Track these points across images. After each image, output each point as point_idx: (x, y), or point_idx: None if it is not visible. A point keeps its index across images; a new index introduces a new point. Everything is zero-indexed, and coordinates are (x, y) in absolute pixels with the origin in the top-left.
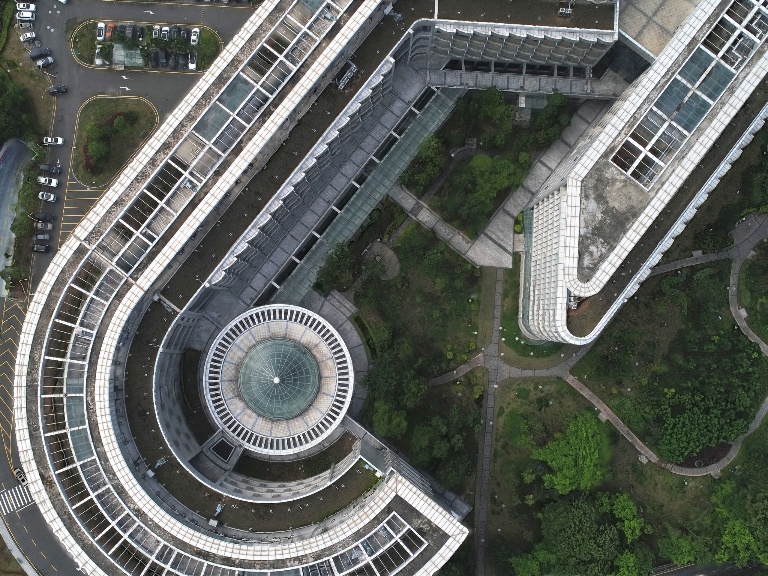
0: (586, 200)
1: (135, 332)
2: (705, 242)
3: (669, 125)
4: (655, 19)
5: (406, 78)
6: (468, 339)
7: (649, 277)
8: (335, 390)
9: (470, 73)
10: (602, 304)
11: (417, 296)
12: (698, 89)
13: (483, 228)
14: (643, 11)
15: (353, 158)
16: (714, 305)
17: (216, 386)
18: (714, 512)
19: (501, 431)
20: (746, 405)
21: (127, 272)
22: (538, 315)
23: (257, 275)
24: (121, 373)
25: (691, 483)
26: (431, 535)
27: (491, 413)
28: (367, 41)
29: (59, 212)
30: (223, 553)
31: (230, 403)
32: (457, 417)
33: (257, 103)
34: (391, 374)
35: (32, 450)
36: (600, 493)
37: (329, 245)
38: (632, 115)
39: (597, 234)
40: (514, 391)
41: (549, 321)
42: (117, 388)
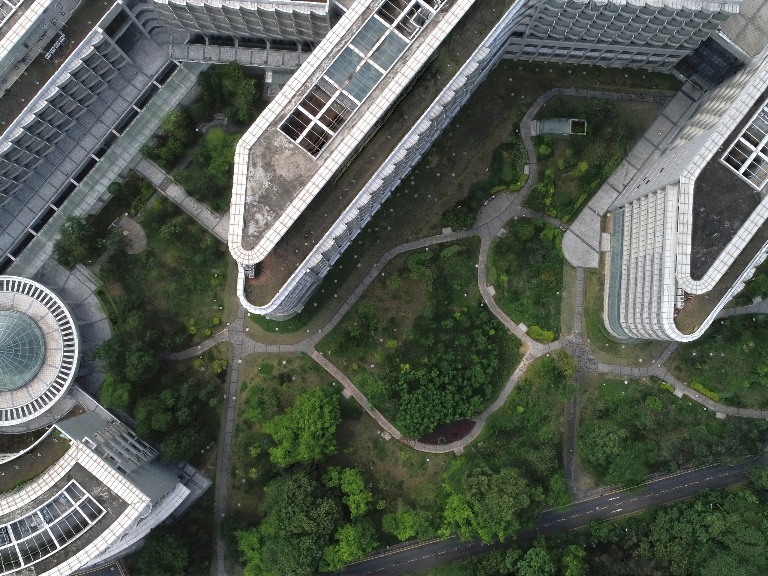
0: (254, 168)
1: None
2: (448, 219)
3: (340, 94)
4: None
5: (149, 52)
6: (213, 314)
7: (398, 254)
8: (60, 362)
9: (213, 47)
10: (284, 274)
11: (162, 270)
12: (371, 58)
13: None
14: None
15: (93, 131)
16: (461, 282)
17: None
18: (440, 487)
19: (244, 406)
20: (481, 381)
21: None
22: None
23: None
24: None
25: (433, 460)
26: (110, 503)
27: (234, 388)
28: (78, 11)
29: None
30: None
31: None
32: (186, 390)
33: None
34: (113, 346)
35: None
36: (331, 468)
37: (66, 218)
38: (303, 84)
39: (263, 202)
40: (258, 366)
41: None
42: None
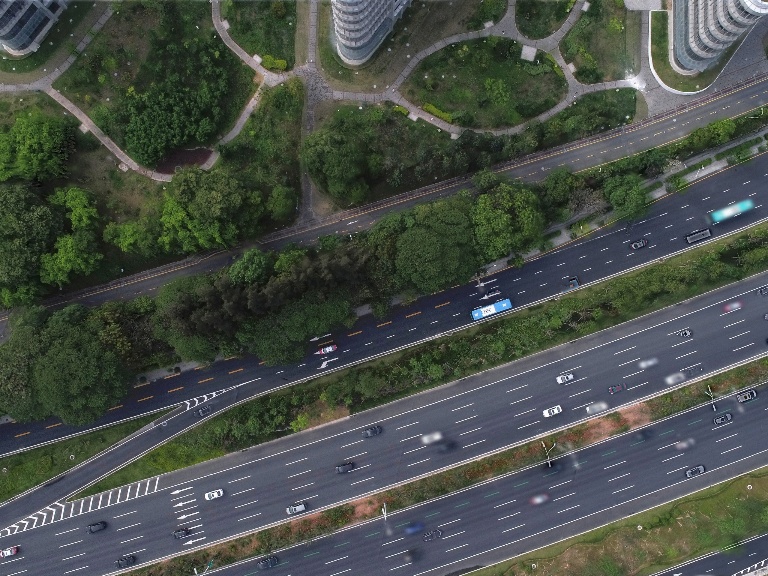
0: None
1: None
2: None
3: None
4: None
5: None
6: None
7: None
8: None
9: None
10: None
11: None
12: None
13: None
14: None
15: None
16: (194, 17)
17: None
18: (162, 199)
19: None
20: (207, 101)
21: None
22: None
23: None
24: None
25: None
26: None
27: None
28: None
29: None
30: None
31: None
32: None
33: None
34: None
35: None
36: (58, 188)
37: None
38: None
39: None
40: None
41: None
42: None
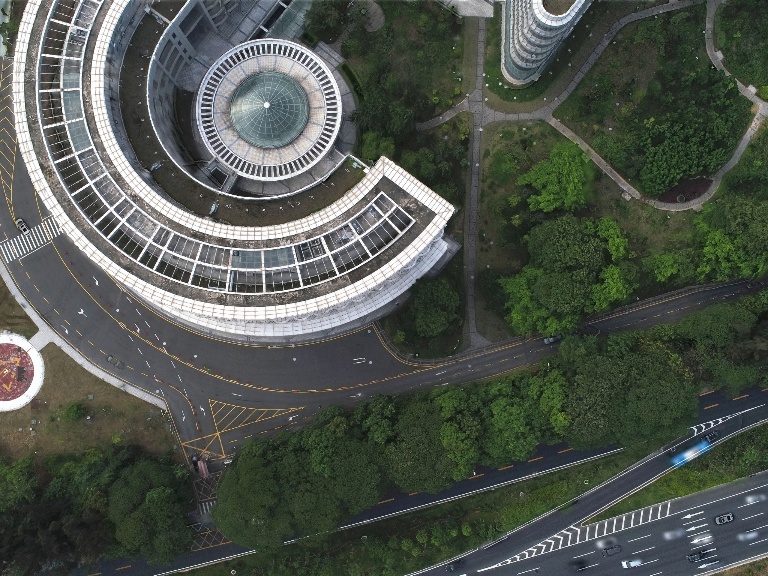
0: None
1: (128, 43)
2: None
3: None
4: None
5: None
6: (453, 85)
7: (627, 23)
8: (324, 119)
9: None
10: None
11: (402, 45)
12: None
13: None
14: None
15: None
16: (691, 47)
17: (209, 118)
18: (695, 229)
19: (487, 172)
20: (724, 133)
21: None
22: (518, 33)
23: (246, 20)
24: (116, 78)
25: (673, 217)
26: (418, 214)
27: (477, 155)
28: None
29: None
30: (218, 234)
31: (223, 134)
32: (443, 146)
33: None
34: (378, 99)
35: (31, 142)
36: (584, 218)
37: None
38: None
39: None
40: (499, 134)
41: (527, 20)
42: (112, 89)
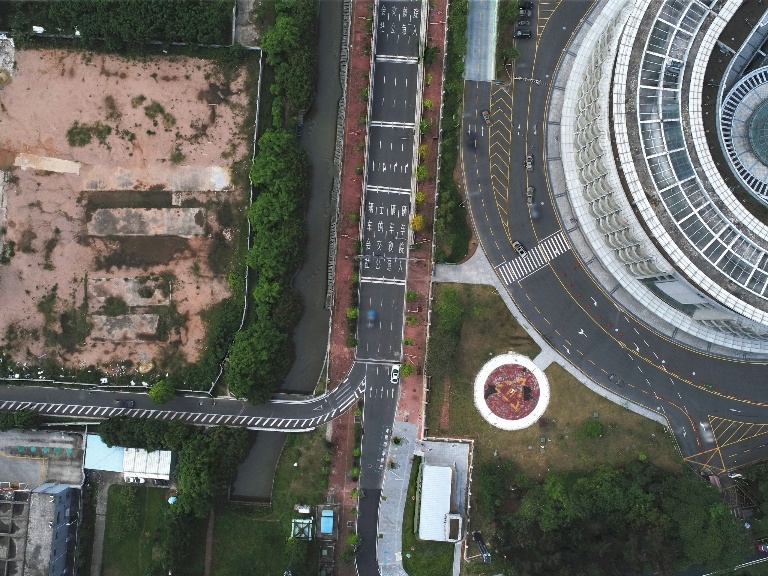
0: None
1: None
2: None
3: None
4: None
5: None
6: None
7: None
8: None
9: None
10: None
11: None
12: None
13: None
14: None
15: None
16: None
17: (728, 142)
18: None
19: None
20: None
21: (708, 6)
22: None
23: None
24: None
25: None
26: None
27: None
28: None
29: (535, 0)
30: None
31: (742, 158)
32: None
33: None
34: None
35: (636, 172)
36: None
37: None
38: None
39: None
40: None
41: None
42: None
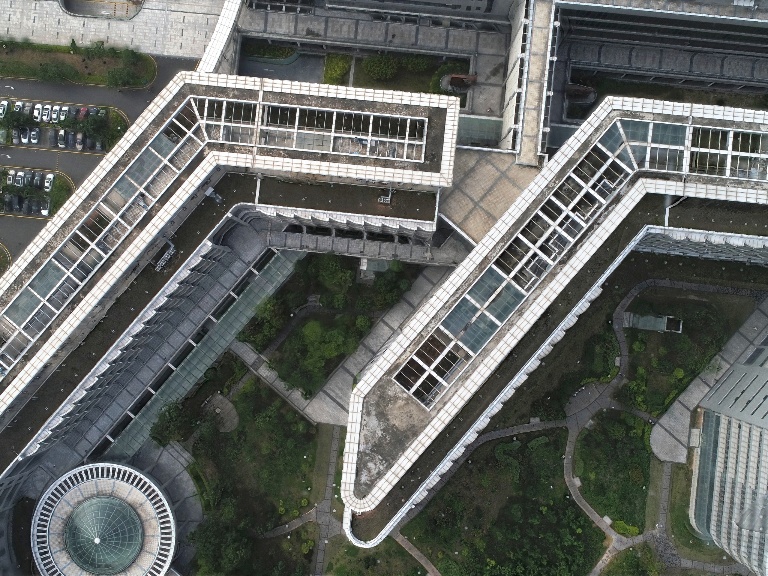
0: (367, 416)
1: None
2: (538, 414)
3: (455, 345)
4: (482, 205)
5: (247, 238)
6: (301, 494)
7: (485, 441)
8: (157, 549)
9: (311, 236)
10: (389, 509)
11: (253, 450)
12: (487, 309)
13: (321, 386)
14: (470, 196)
15: (191, 317)
16: (547, 473)
17: (44, 539)
18: None
19: None
20: None
21: None
22: None
23: (92, 428)
24: None
25: None
26: None
27: (320, 568)
28: (188, 221)
29: None
30: None
31: (56, 556)
32: None
33: (68, 289)
34: (210, 539)
35: None
36: None
37: (163, 402)
38: (418, 333)
39: (376, 451)
40: (344, 548)
41: None
42: None
